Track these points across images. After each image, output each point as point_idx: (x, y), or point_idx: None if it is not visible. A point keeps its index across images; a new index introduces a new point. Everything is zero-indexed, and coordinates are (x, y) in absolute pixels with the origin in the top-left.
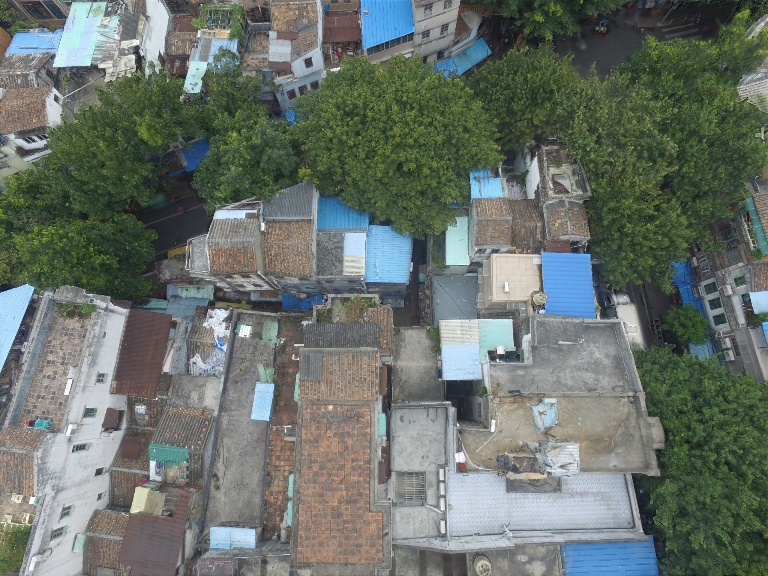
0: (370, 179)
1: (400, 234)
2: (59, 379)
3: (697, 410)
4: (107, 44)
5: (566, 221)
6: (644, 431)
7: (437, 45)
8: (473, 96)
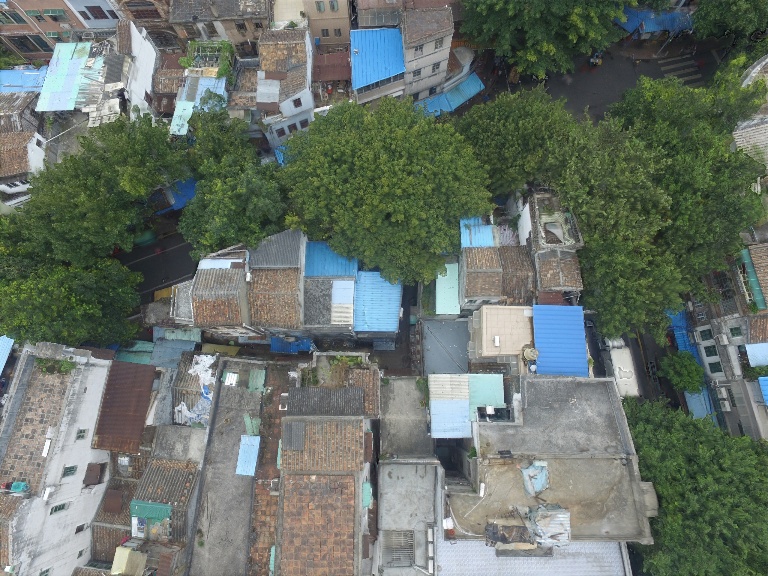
0: (358, 228)
1: (389, 281)
2: (37, 438)
3: (691, 476)
4: (91, 87)
5: (558, 272)
6: (637, 496)
7: (429, 82)
8: (464, 139)
